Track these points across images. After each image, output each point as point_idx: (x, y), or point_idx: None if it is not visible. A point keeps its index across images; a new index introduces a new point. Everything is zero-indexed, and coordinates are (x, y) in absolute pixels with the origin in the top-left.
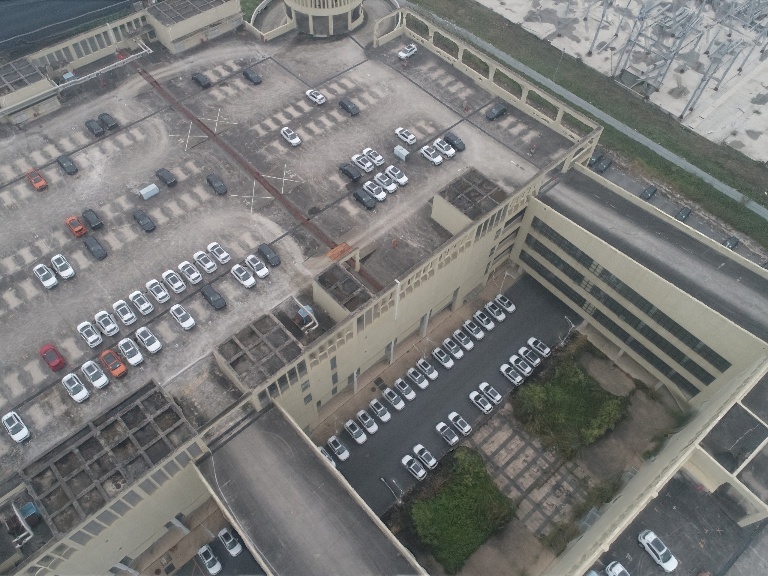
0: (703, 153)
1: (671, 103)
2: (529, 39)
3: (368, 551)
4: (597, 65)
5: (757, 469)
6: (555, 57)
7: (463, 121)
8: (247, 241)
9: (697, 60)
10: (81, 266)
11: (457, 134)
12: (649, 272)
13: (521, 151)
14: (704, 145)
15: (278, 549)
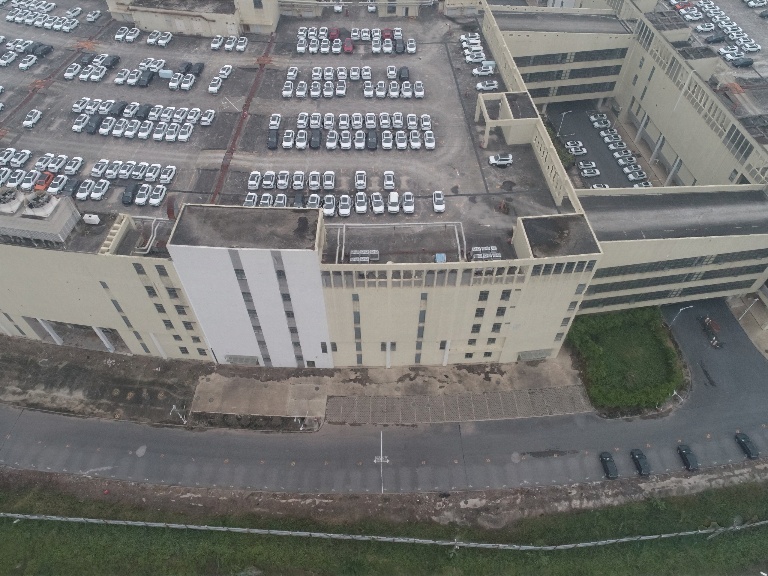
0: None
1: None
2: None
3: (546, 31)
4: None
5: (495, 142)
6: None
7: None
8: (760, 62)
9: None
10: (757, 11)
11: None
12: None
13: None
14: None
15: (563, 17)
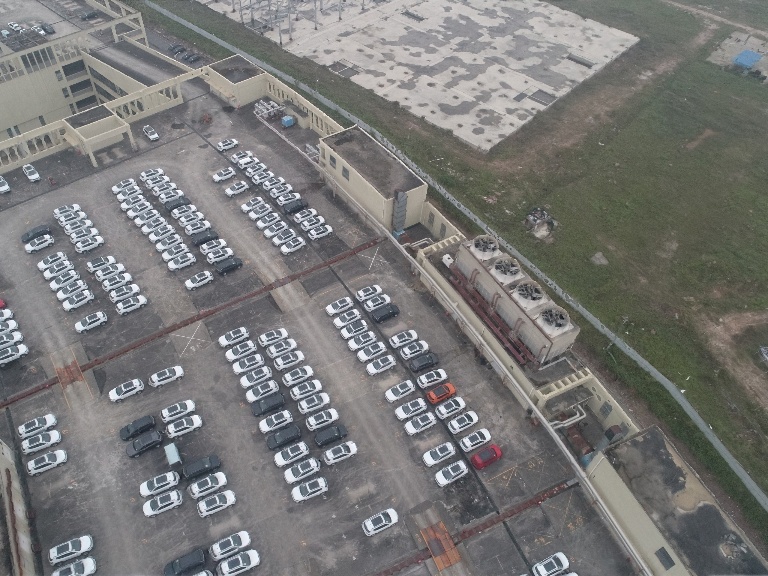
0: (286, 62)
1: (278, 36)
2: (193, 4)
3: None
4: (236, 17)
5: (124, 147)
6: (207, 14)
7: (64, 21)
8: None
9: (312, 14)
10: None
11: (55, 27)
12: (125, 76)
13: (95, 34)
14: (289, 58)
15: None
